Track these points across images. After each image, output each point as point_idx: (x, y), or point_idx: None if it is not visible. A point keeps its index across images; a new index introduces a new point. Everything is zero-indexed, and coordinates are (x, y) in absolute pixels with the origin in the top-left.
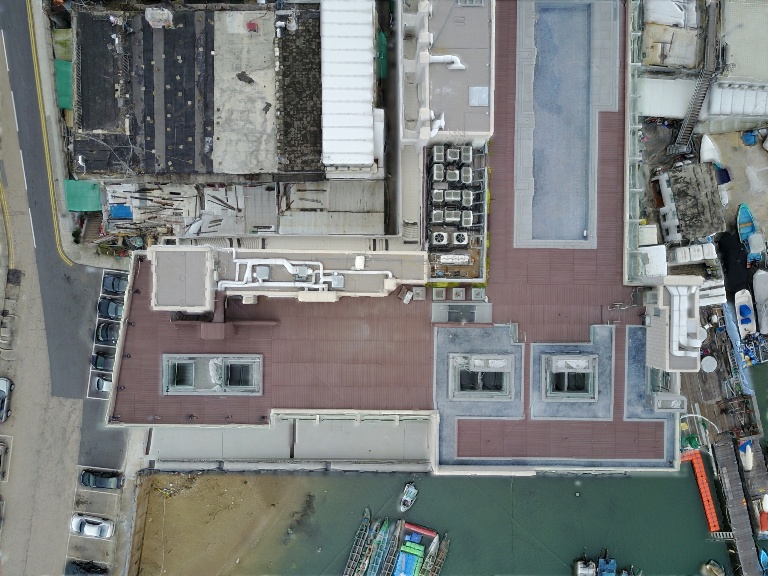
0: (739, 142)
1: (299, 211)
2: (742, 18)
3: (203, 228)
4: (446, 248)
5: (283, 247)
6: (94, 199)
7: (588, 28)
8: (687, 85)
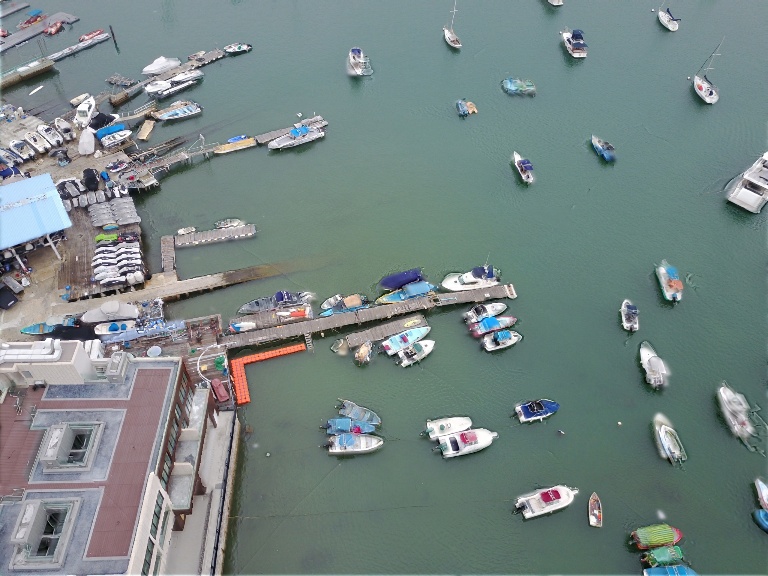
0: None
1: None
2: None
3: None
4: None
5: None
6: None
7: None
8: None
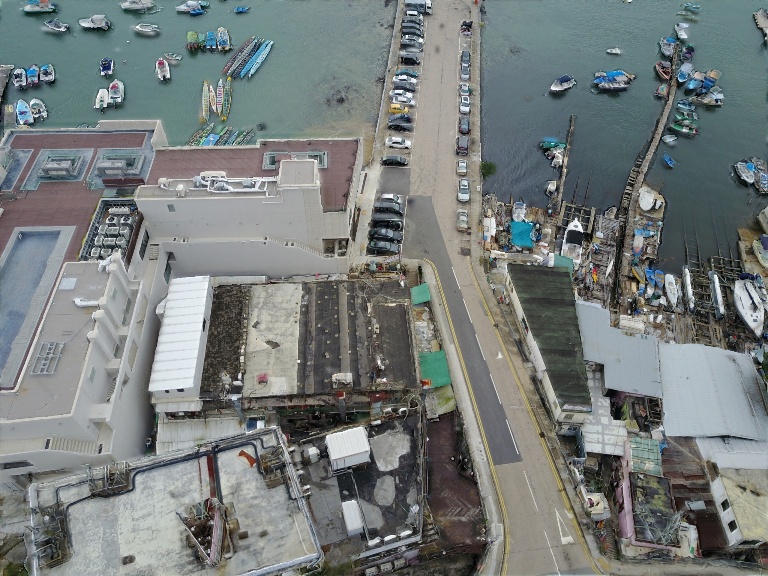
0: None
1: None
2: None
3: None
4: None
5: None
6: None
7: None
8: None
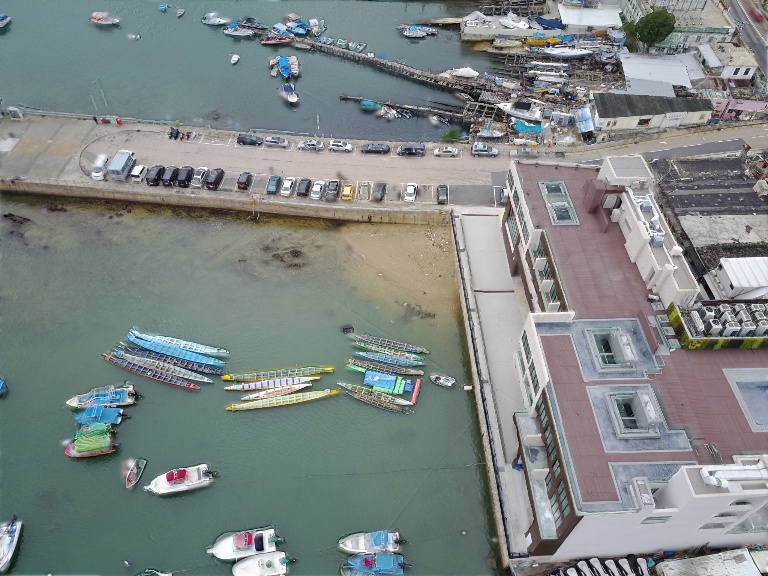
0: None
1: None
2: None
3: None
4: None
5: None
6: None
7: None
8: None
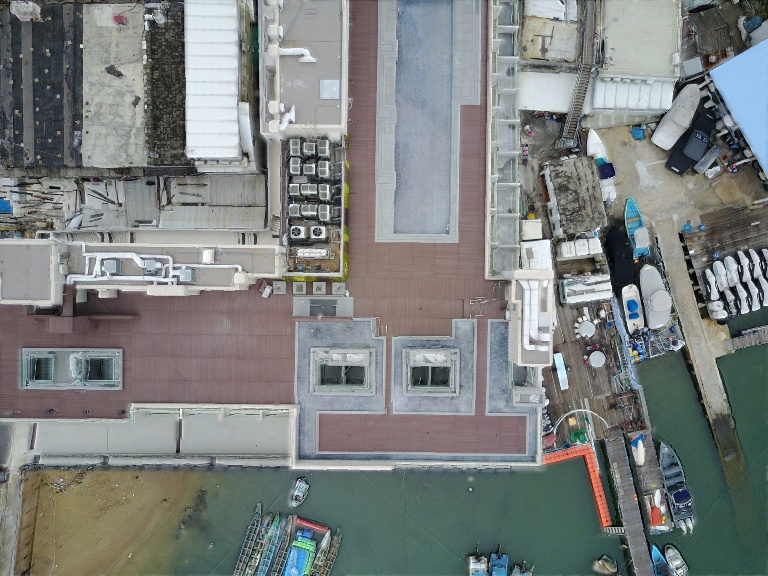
0: (629, 136)
1: (180, 205)
2: (624, 11)
3: (84, 222)
4: (307, 242)
5: (152, 241)
6: None
7: (452, 21)
8: (571, 79)
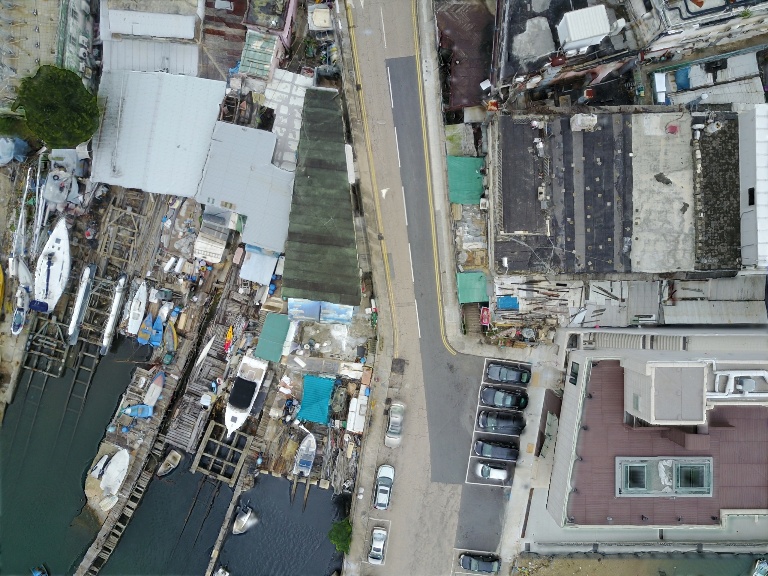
0: None
1: (681, 300)
2: None
3: (586, 318)
4: None
5: (704, 345)
6: (480, 290)
7: None
8: None
